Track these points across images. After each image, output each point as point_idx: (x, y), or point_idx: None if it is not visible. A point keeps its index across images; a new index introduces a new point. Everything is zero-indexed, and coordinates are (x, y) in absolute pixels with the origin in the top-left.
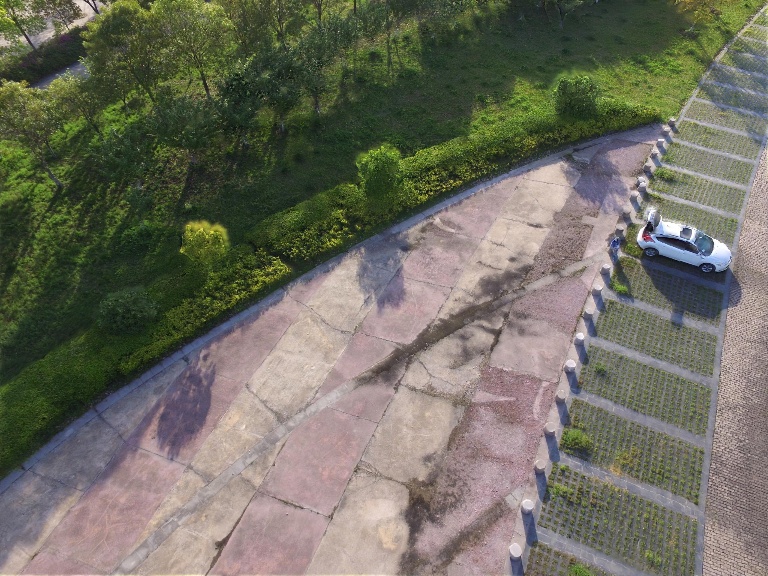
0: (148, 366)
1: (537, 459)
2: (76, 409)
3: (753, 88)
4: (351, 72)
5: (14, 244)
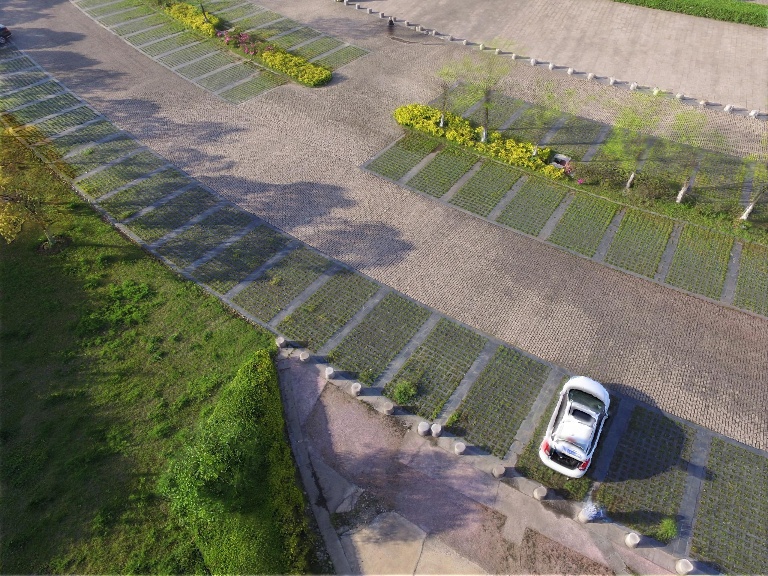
0: None
1: None
2: None
3: (227, 234)
4: None
5: None
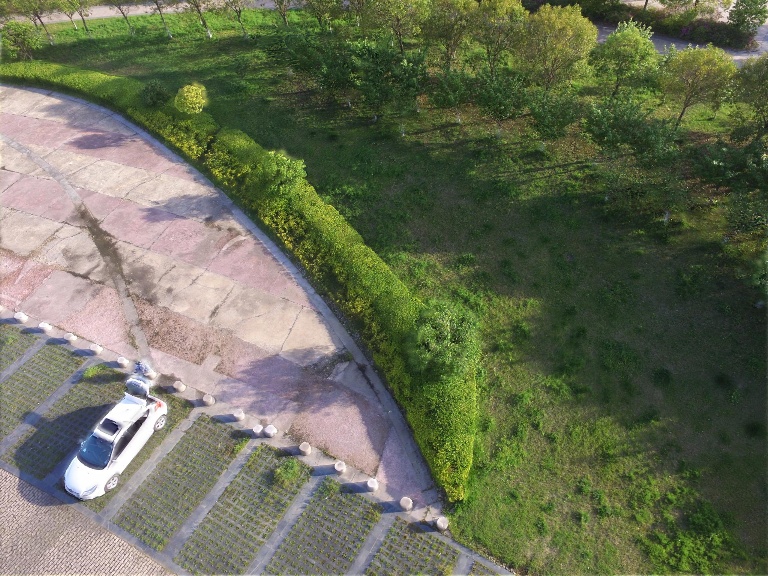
0: (134, 122)
1: None
2: (114, 107)
3: None
4: (491, 144)
5: (241, 50)
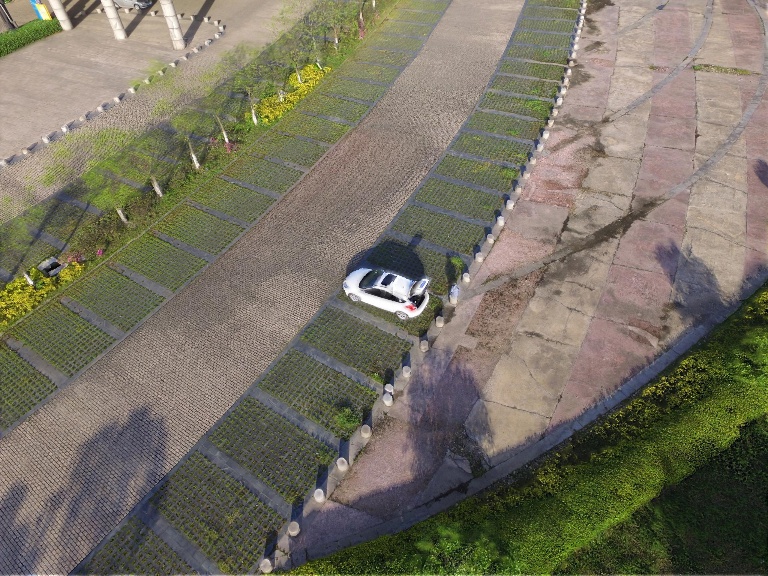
0: None
1: (534, 165)
2: None
3: None
4: None
5: None
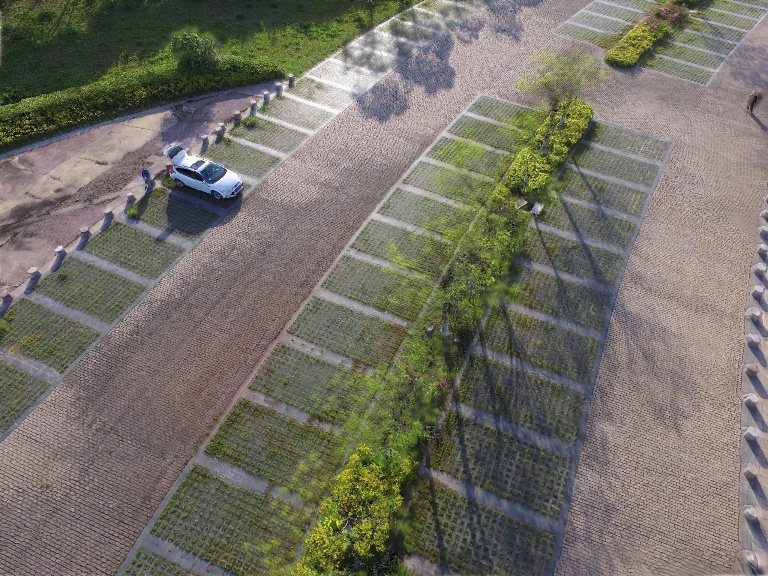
0: None
1: None
2: None
3: (389, 51)
4: (11, 30)
5: None
